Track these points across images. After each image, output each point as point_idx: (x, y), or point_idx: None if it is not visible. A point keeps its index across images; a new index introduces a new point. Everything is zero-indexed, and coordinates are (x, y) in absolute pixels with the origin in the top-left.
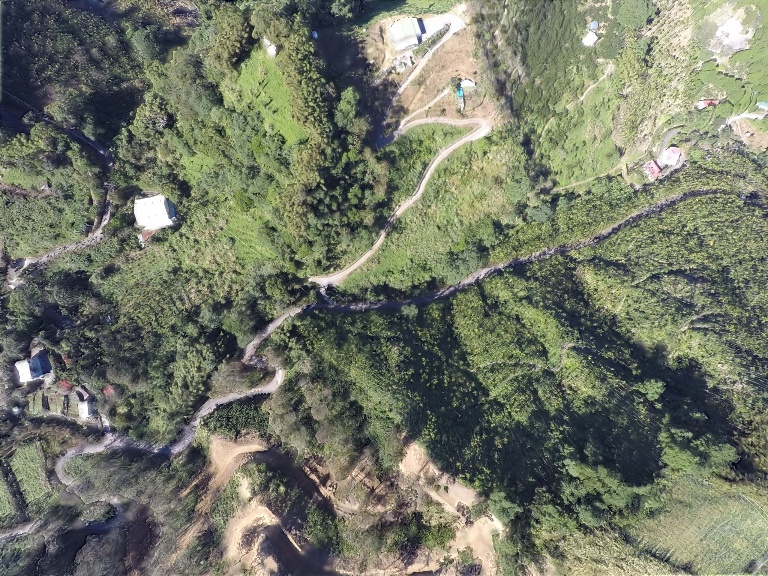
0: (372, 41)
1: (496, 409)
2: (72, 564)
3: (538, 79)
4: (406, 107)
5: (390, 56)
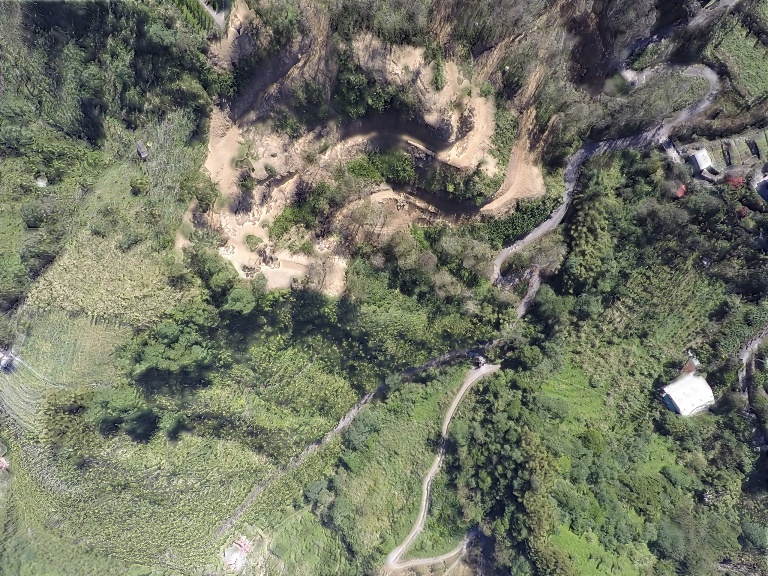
0: None
1: (282, 346)
2: None
3: None
4: (466, 567)
5: None
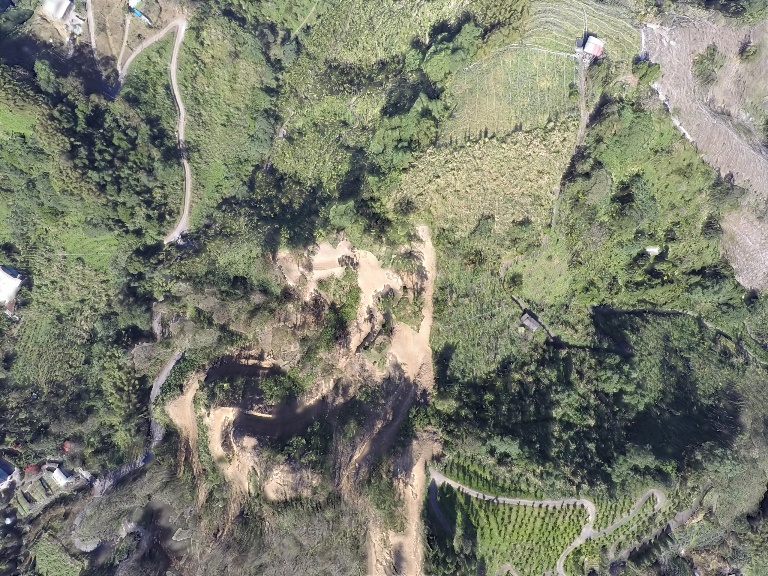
0: (38, 26)
1: None
2: None
3: None
4: (110, 55)
5: (61, 27)
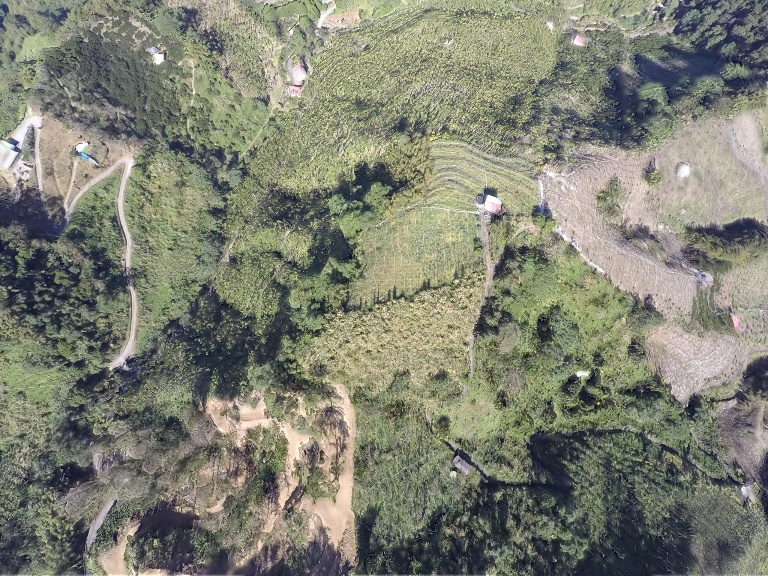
0: None
1: None
2: None
3: (147, 107)
4: (58, 195)
5: (8, 175)
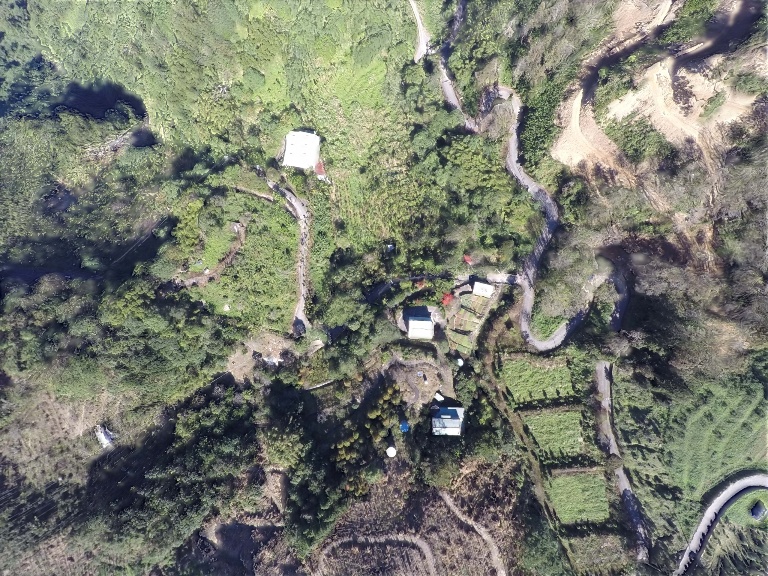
0: None
1: None
2: (666, 303)
3: None
4: None
5: None
